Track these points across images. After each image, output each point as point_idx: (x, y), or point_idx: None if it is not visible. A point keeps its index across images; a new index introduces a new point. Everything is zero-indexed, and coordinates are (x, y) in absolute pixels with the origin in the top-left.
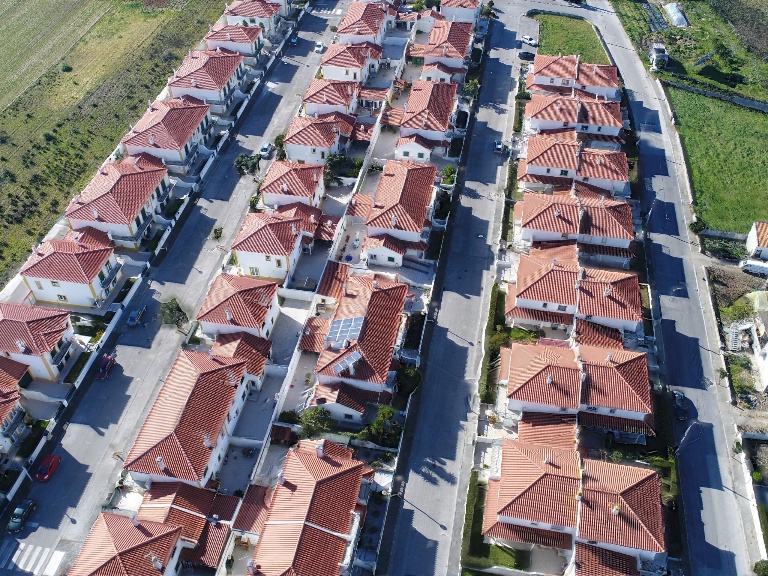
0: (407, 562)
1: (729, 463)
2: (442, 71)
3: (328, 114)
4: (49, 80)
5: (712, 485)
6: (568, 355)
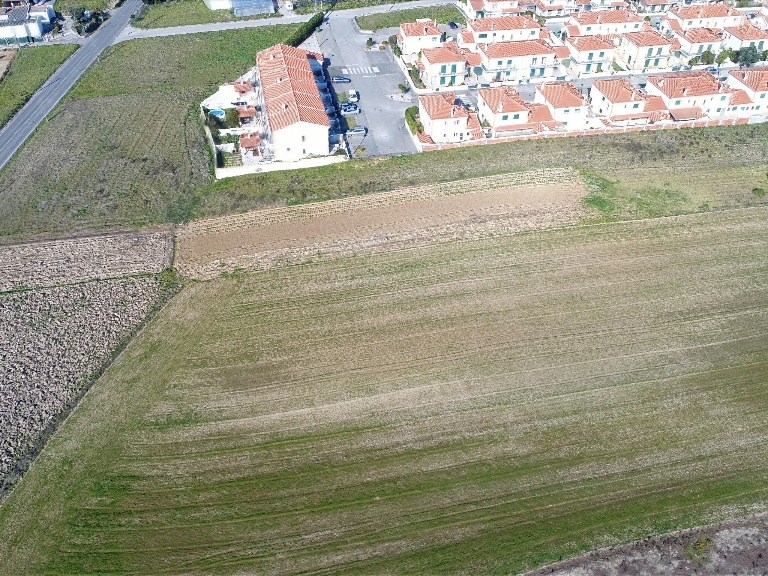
0: None
1: None
2: None
3: None
4: None
5: None
6: None
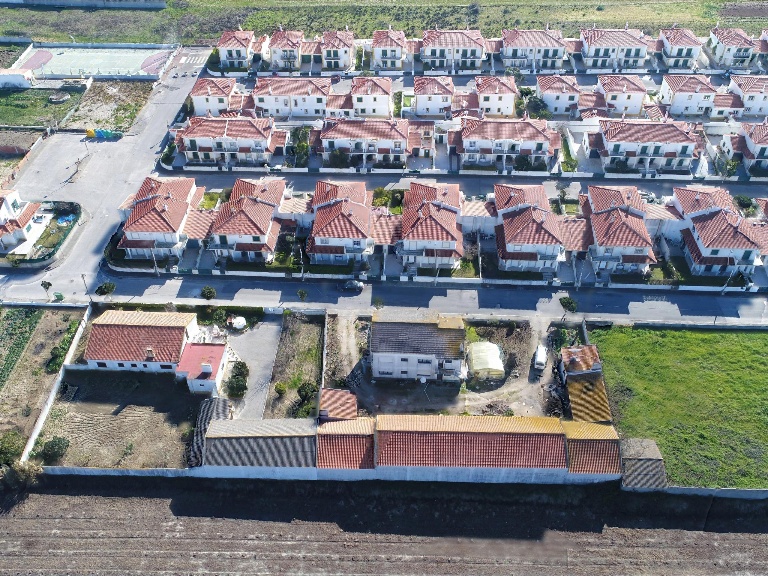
0: (230, 180)
1: (303, 307)
2: (731, 142)
3: (599, 93)
4: (582, 7)
5: (283, 296)
6: (356, 200)
